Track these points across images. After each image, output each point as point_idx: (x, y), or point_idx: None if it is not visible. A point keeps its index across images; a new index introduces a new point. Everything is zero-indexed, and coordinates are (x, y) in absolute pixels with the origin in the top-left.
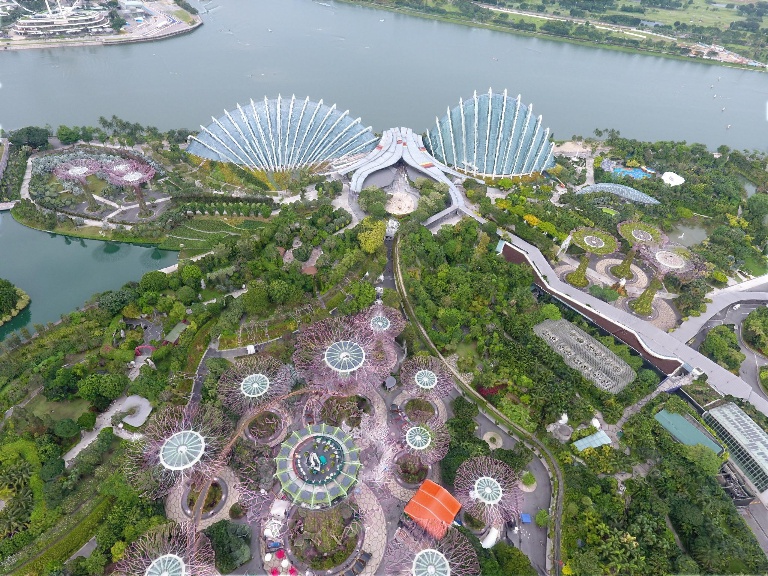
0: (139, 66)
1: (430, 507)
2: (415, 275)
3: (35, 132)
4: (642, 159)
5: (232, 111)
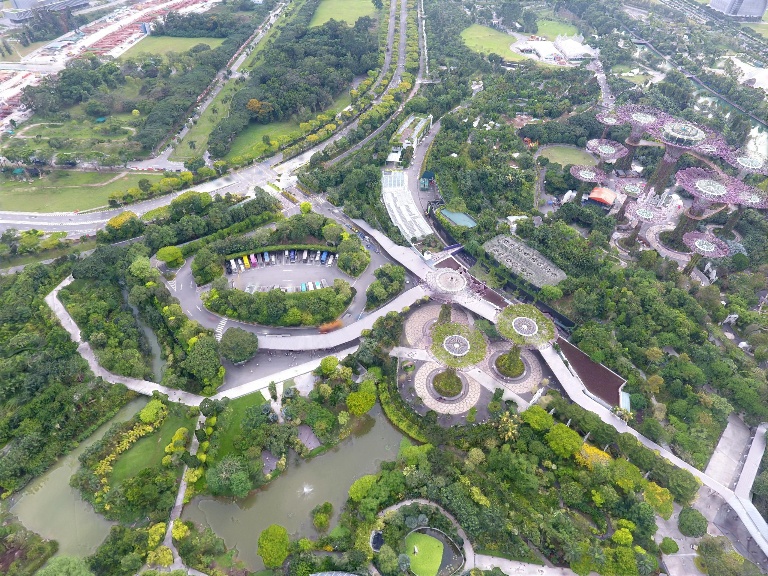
0: None
1: (606, 193)
2: None
3: None
4: None
5: None
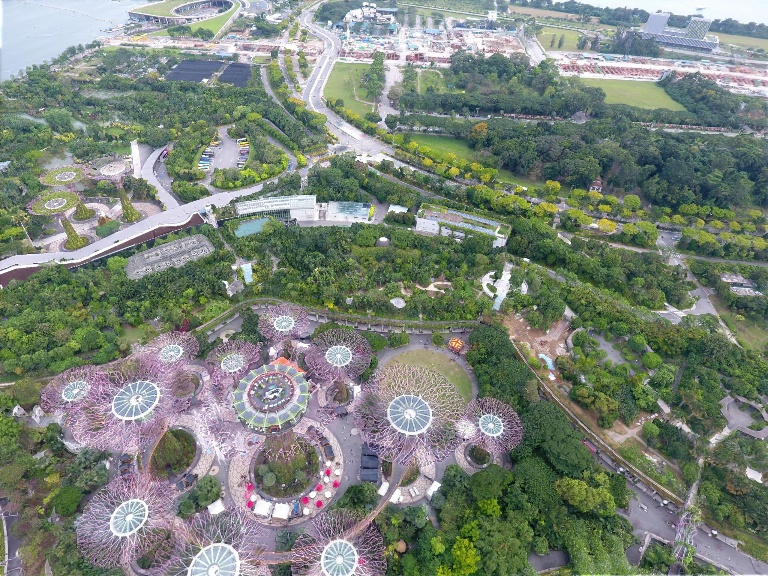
0: None
1: None
2: None
3: None
4: None
5: None
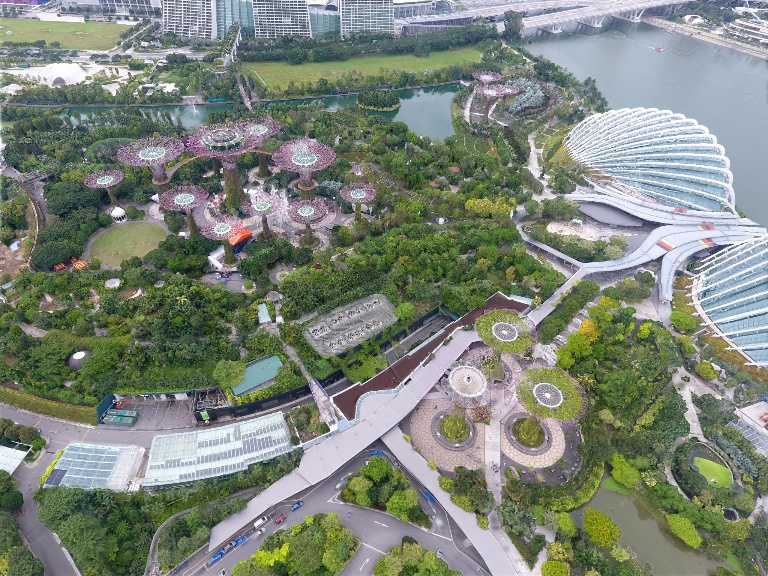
0: (740, 80)
1: None
2: None
3: (547, 66)
4: None
5: None
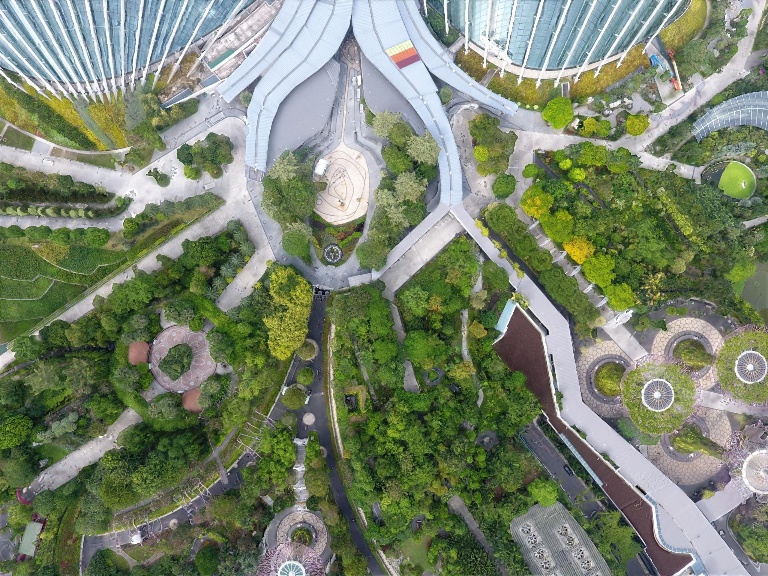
0: None
1: None
2: (358, 394)
3: None
4: None
5: None
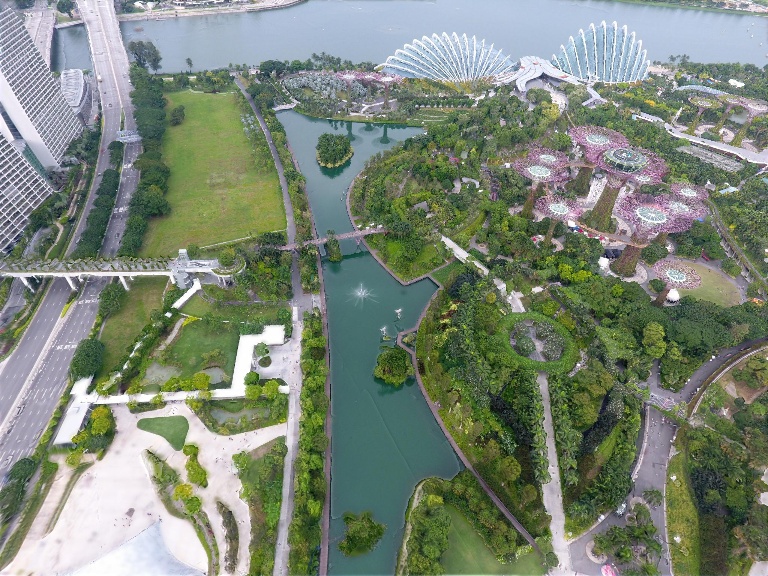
0: (291, 25)
1: None
2: None
3: (278, 63)
4: (710, 73)
5: (412, 45)
